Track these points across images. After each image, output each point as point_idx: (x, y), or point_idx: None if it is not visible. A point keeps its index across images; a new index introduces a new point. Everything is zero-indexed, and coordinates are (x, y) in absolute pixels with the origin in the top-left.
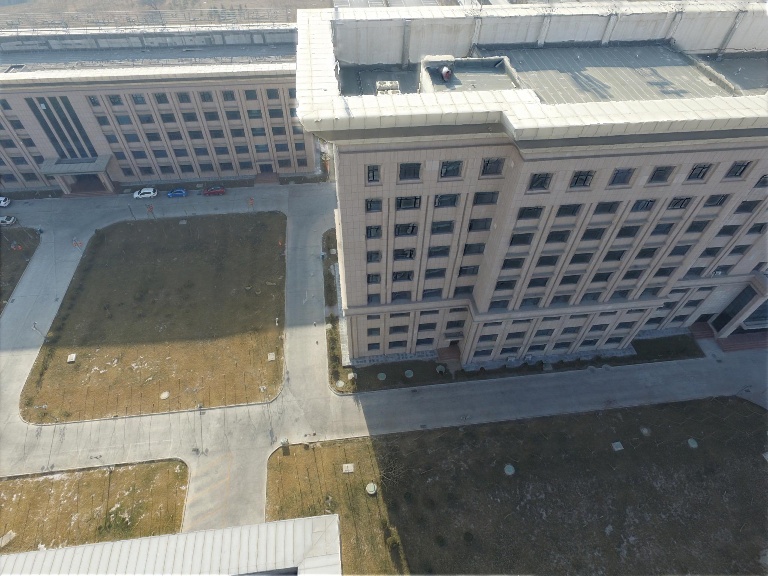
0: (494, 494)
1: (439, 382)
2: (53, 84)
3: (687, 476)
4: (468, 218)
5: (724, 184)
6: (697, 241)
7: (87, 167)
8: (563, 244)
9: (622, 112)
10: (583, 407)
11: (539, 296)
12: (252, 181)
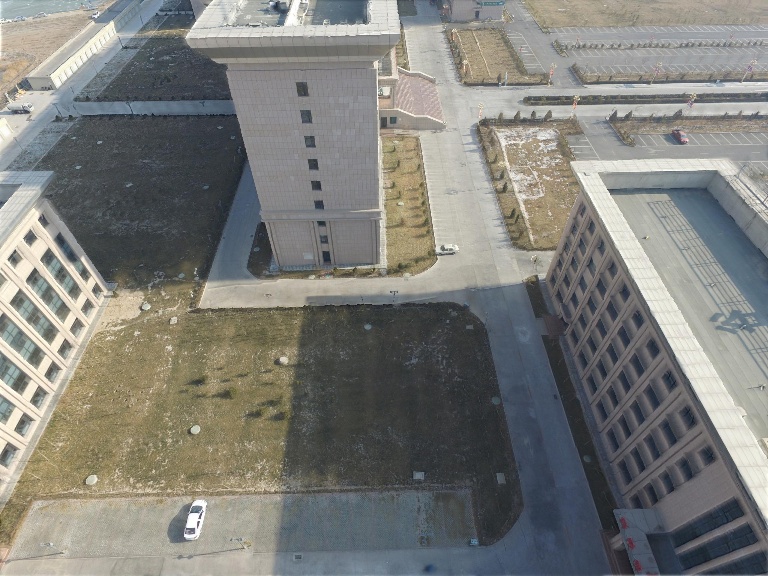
0: None
1: None
2: None
3: None
4: None
5: None
6: None
7: None
8: None
9: None
10: None
11: None
12: None
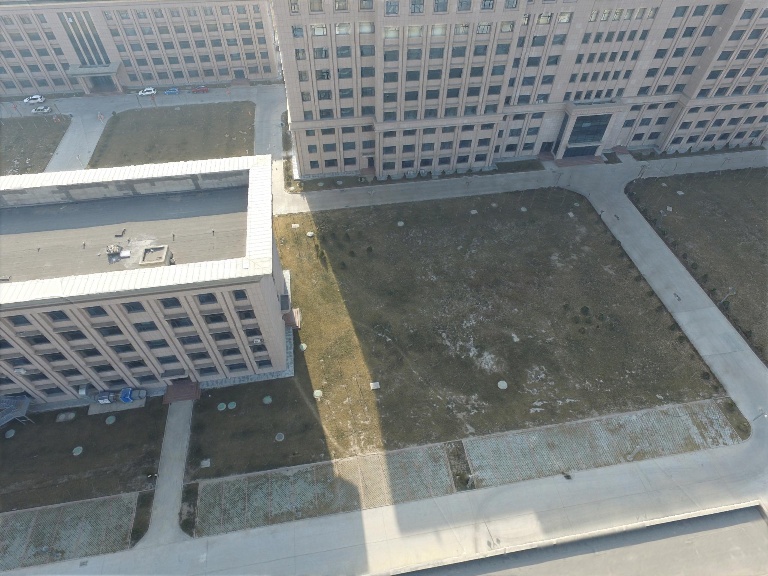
0: (389, 234)
1: (360, 186)
2: (79, 0)
3: (516, 224)
4: (358, 44)
5: (506, 13)
6: (506, 61)
7: (103, 69)
8: (419, 61)
9: None
10: (455, 195)
11: (414, 108)
12: (229, 84)
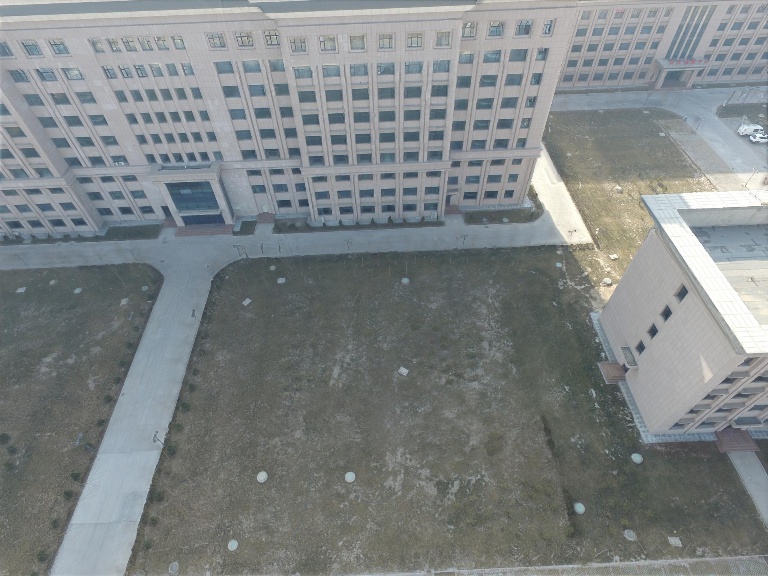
0: None
1: None
2: None
3: (51, 310)
4: None
5: None
6: (15, 123)
7: None
8: None
9: None
10: (25, 266)
11: None
12: None
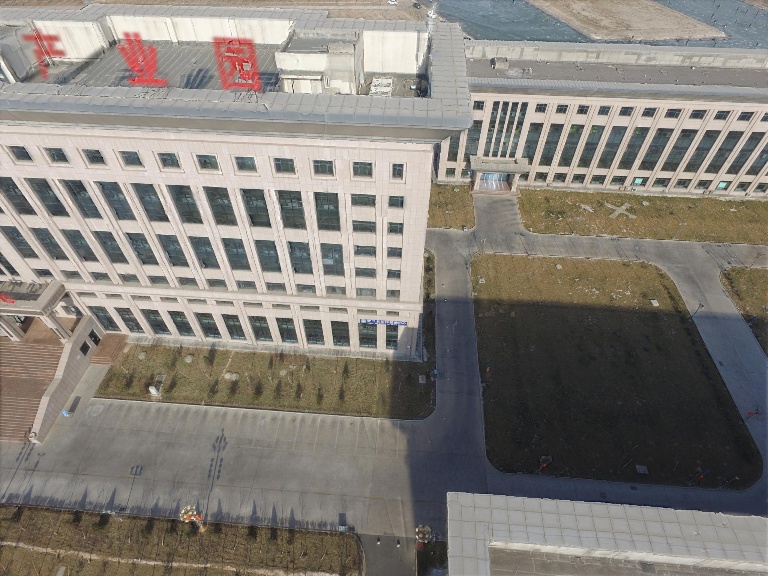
0: None
1: None
2: None
3: None
4: None
5: None
6: None
7: None
8: None
9: (252, 12)
10: None
11: None
12: None
